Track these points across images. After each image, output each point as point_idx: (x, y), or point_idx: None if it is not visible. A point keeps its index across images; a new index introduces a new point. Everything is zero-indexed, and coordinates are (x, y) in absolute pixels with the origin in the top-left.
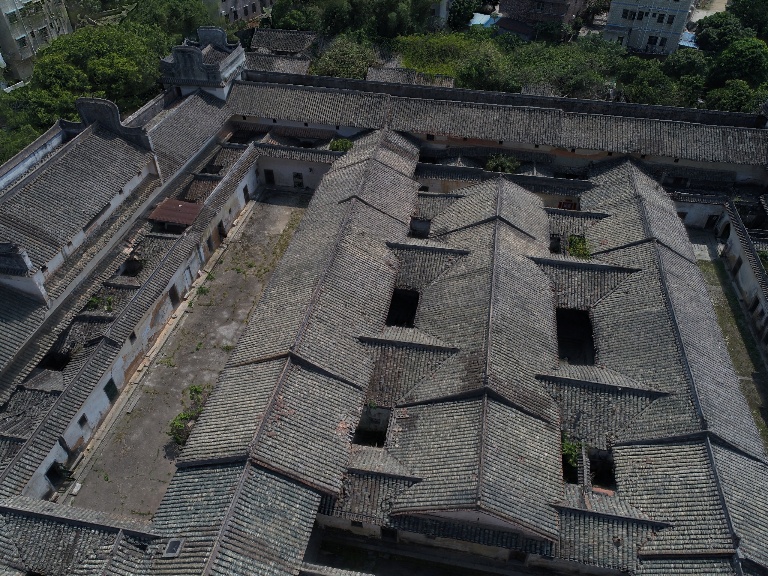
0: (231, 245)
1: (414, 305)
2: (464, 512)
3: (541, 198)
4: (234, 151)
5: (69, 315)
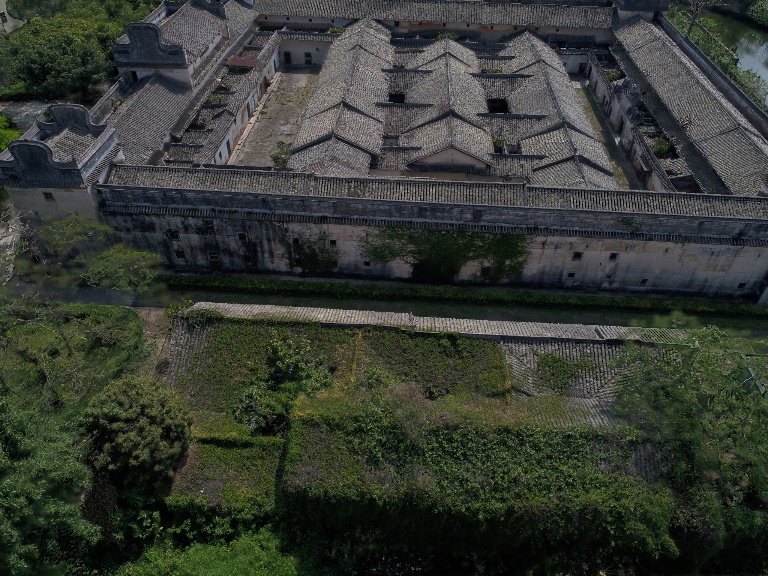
0: (272, 93)
1: (402, 100)
2: (445, 156)
3: (473, 52)
4: (264, 37)
5: (199, 104)
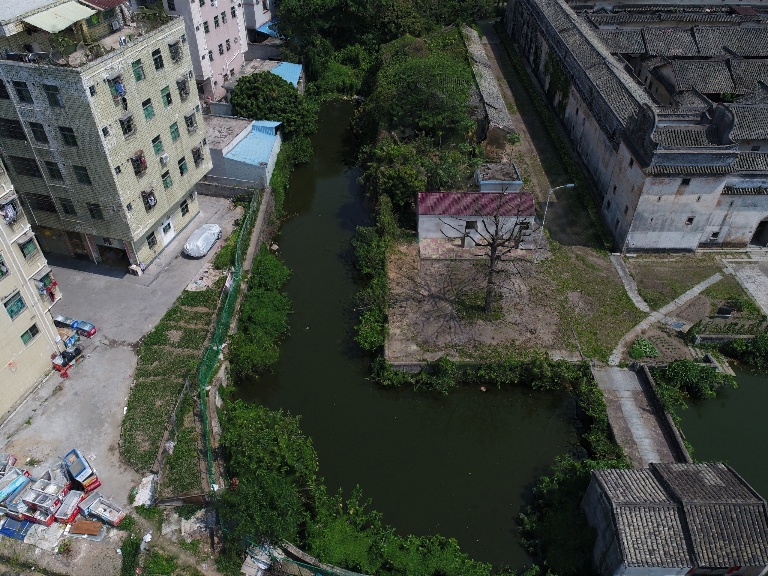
0: None
1: None
2: None
3: None
4: None
5: (661, 8)
